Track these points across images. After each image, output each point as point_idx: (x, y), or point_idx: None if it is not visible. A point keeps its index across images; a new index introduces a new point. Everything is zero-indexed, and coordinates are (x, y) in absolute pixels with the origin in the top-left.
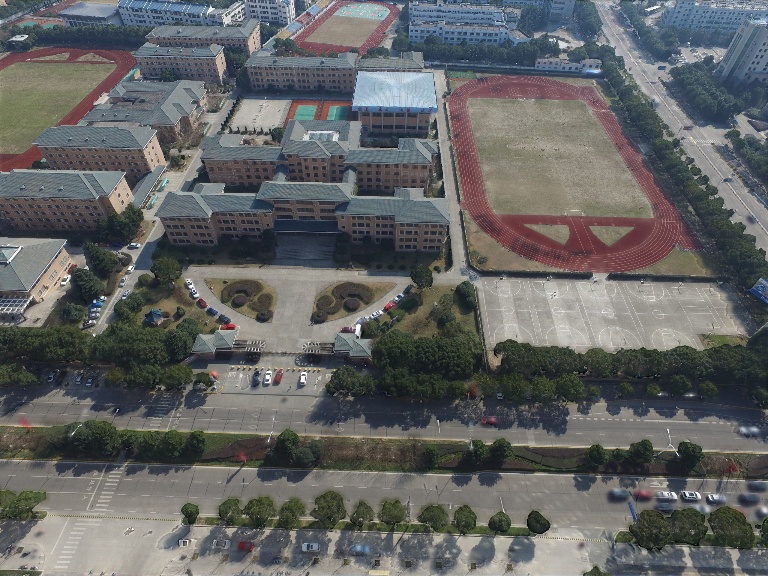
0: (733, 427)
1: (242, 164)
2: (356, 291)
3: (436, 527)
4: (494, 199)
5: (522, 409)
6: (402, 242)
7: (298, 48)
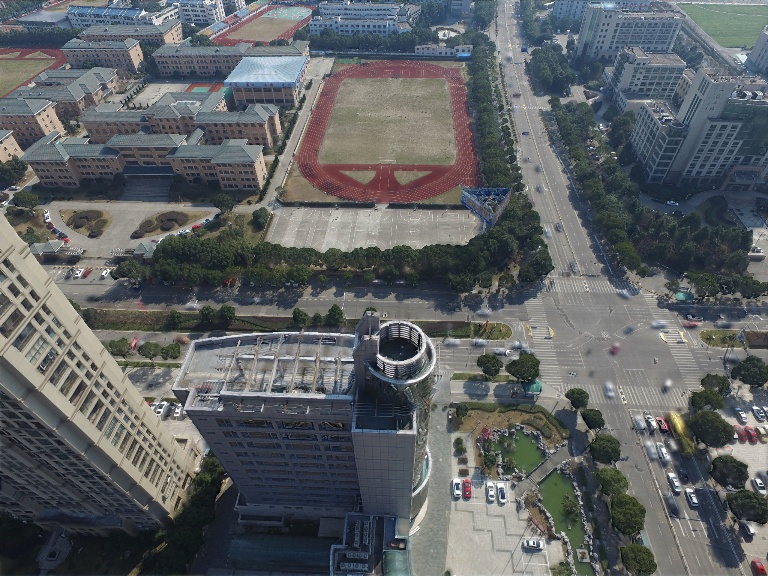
0: (428, 305)
1: (114, 126)
2: (174, 216)
3: (144, 353)
4: (324, 153)
5: (267, 293)
6: (225, 181)
7: (210, 42)
